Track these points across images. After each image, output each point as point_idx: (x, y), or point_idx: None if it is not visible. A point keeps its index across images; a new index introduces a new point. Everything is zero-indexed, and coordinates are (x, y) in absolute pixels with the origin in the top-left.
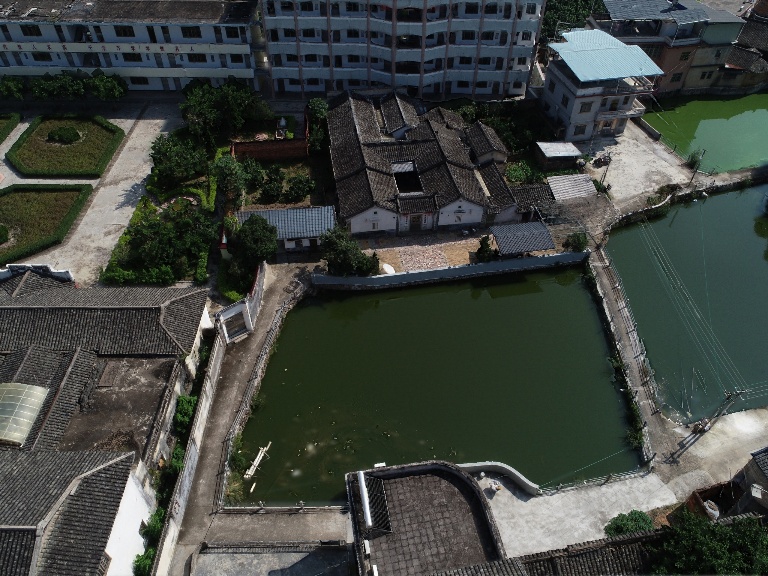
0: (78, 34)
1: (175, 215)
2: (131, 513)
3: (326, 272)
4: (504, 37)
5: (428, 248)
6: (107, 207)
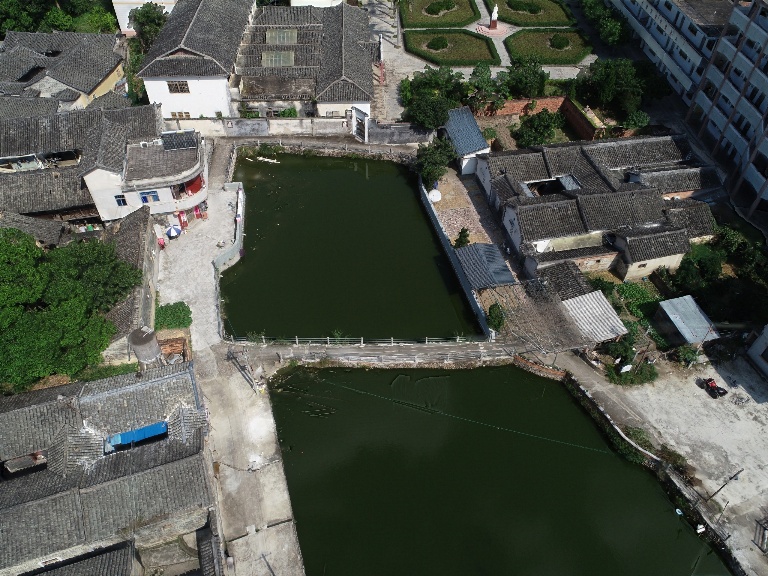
0: None
1: None
2: (215, 98)
3: None
4: None
5: (477, 224)
6: None
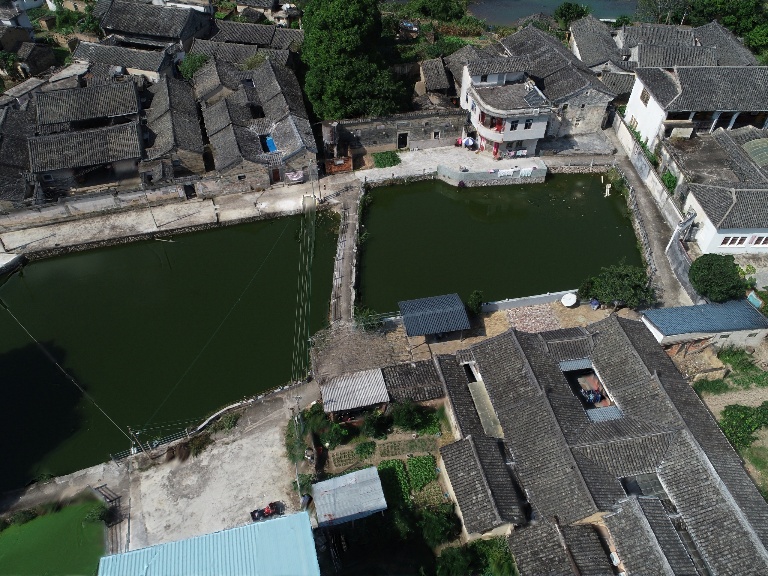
0: None
1: None
2: None
3: (633, 308)
4: None
5: None
6: None
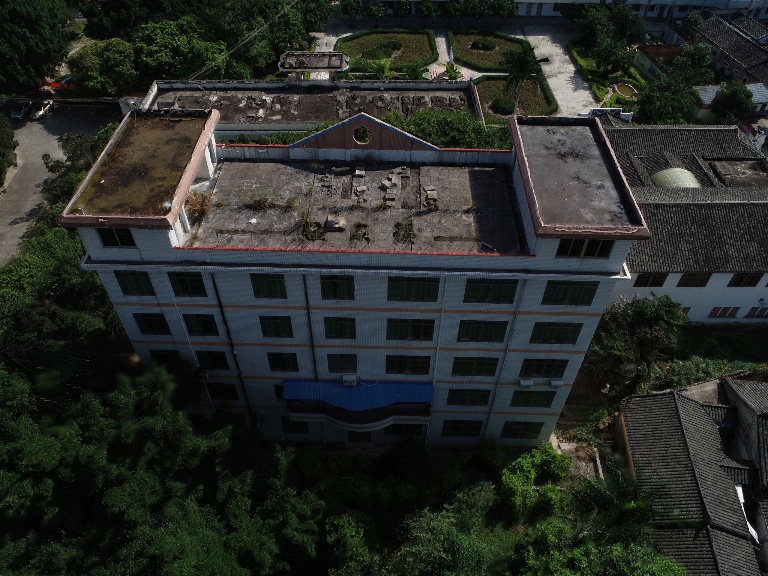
0: None
1: (664, 85)
2: None
3: None
4: None
5: None
6: (566, 90)
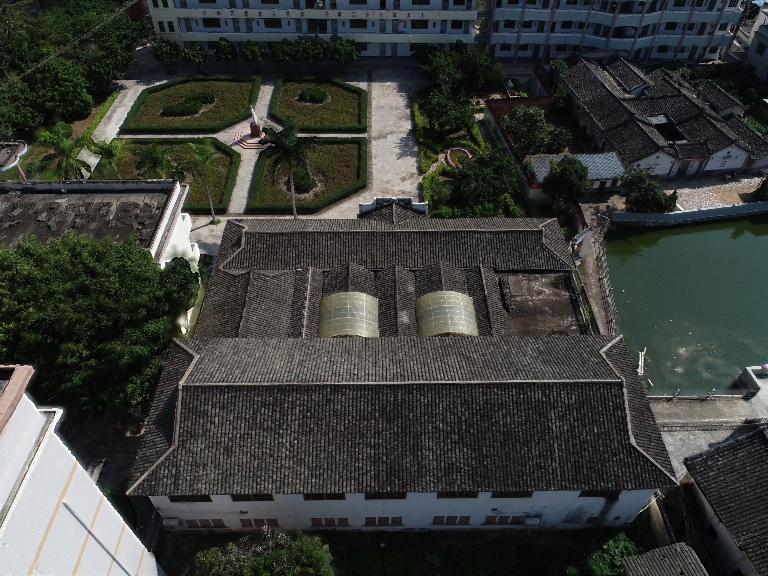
0: (309, 2)
1: (487, 158)
2: None
3: None
4: (712, 4)
5: (699, 190)
6: (389, 157)
